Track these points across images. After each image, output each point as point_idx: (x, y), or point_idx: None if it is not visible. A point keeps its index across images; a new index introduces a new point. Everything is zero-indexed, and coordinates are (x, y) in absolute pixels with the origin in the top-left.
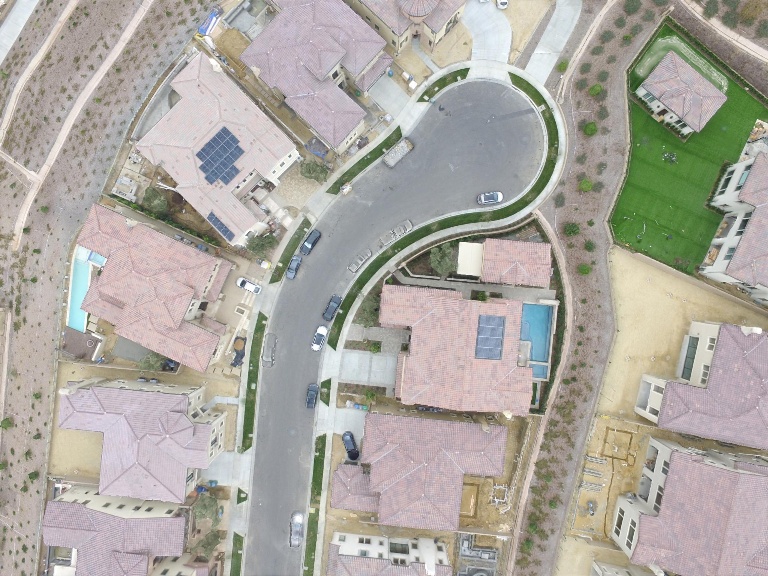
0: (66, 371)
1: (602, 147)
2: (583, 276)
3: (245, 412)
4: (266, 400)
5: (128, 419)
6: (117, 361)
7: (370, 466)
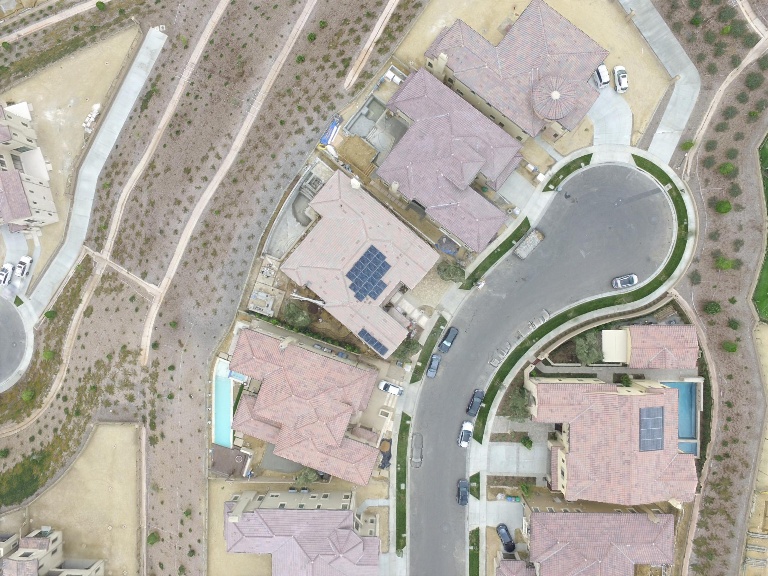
0: (216, 487)
1: (737, 224)
2: (727, 352)
3: (396, 513)
4: (416, 499)
5: (298, 541)
6: (266, 474)
7: (539, 564)
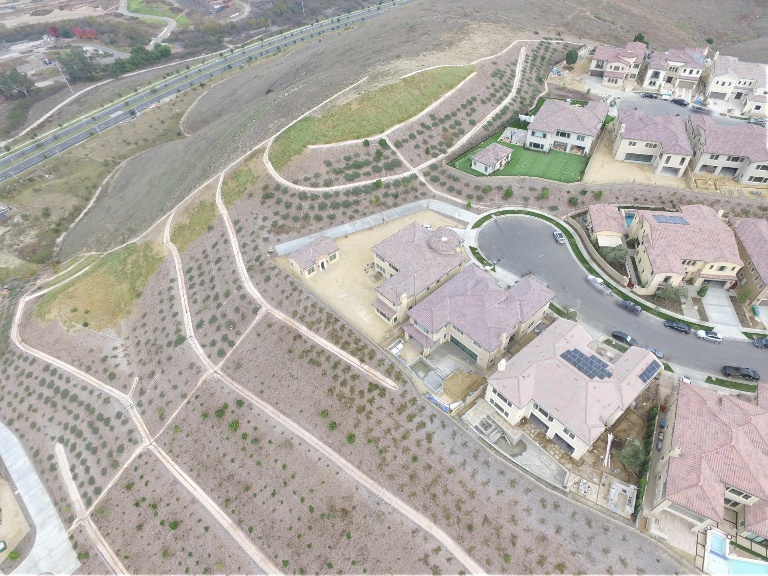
0: None
1: (519, 189)
2: (601, 198)
3: None
4: None
5: None
6: None
7: None
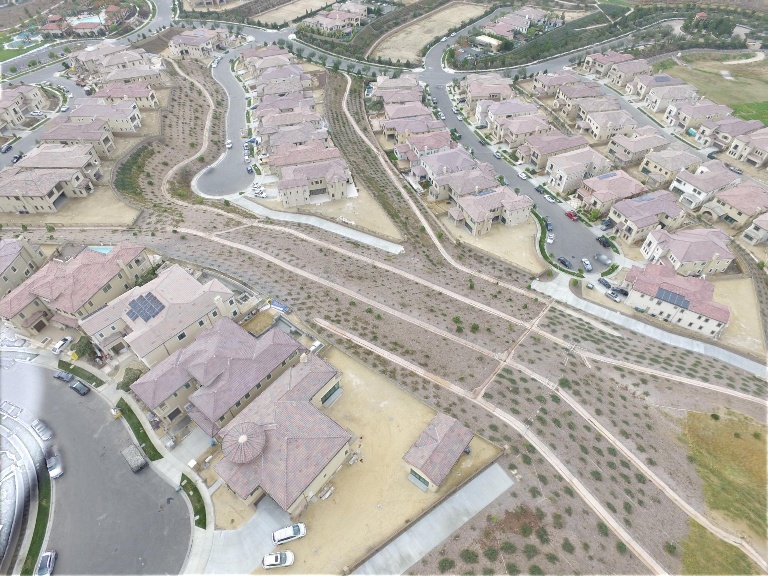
0: None
1: None
2: None
3: None
4: None
5: None
6: None
7: None
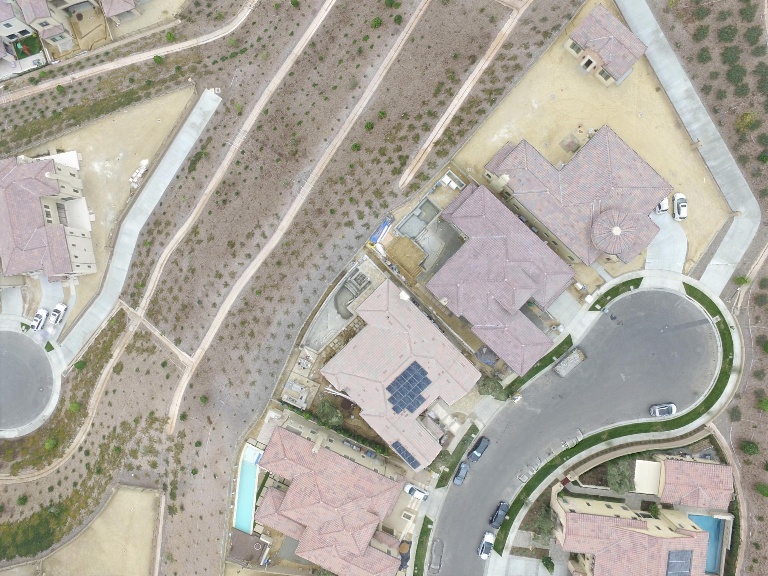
0: (231, 571)
1: None
2: (761, 494)
3: None
4: None
5: None
6: (283, 563)
7: None
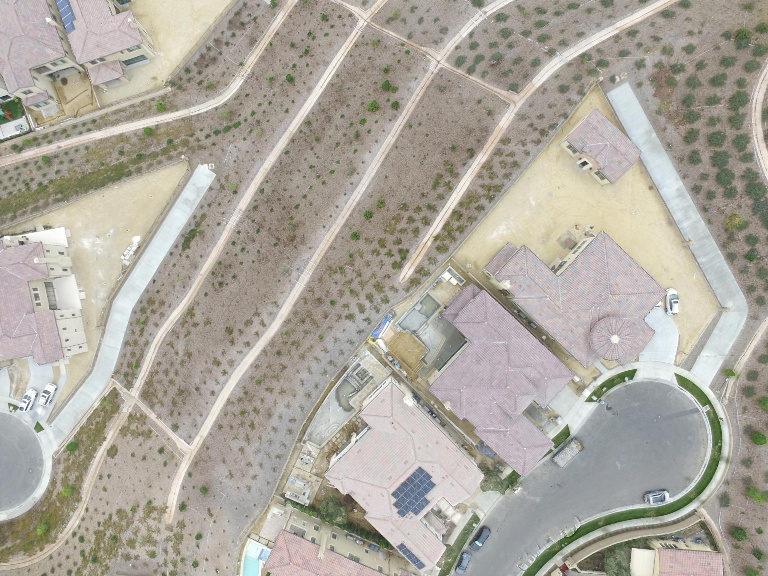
0: None
1: None
2: None
3: None
4: None
5: None
6: None
7: None
